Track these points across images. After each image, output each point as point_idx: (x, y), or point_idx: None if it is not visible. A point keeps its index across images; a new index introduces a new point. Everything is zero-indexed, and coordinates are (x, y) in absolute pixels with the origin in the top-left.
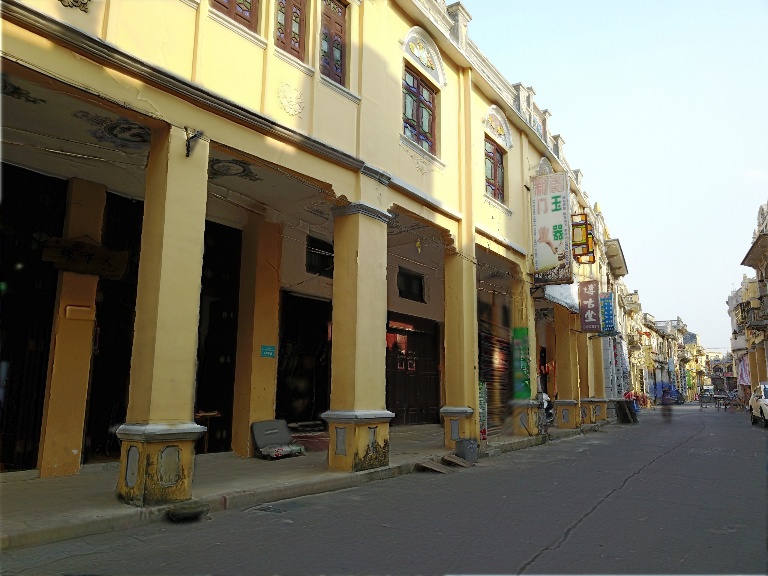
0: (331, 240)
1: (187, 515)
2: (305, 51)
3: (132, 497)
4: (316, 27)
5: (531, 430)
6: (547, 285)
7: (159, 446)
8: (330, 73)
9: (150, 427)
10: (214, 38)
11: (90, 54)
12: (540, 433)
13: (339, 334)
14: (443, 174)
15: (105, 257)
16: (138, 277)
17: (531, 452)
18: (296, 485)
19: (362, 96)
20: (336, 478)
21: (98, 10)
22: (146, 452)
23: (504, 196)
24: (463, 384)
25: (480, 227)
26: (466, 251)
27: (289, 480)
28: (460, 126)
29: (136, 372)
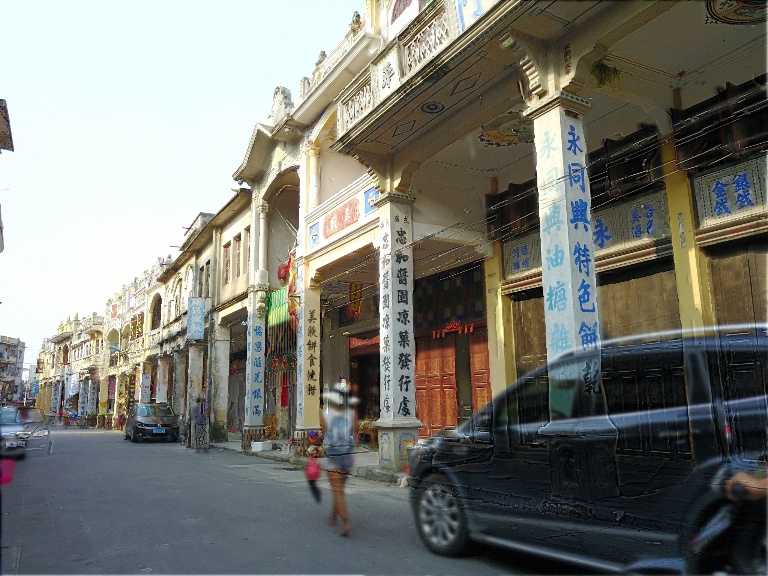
0: None
1: None
2: None
3: None
4: None
5: None
6: None
7: None
8: None
9: None
10: None
11: None
12: None
13: None
14: None
15: None
16: None
17: None
18: None
19: None
20: None
21: None
22: None
23: None
24: None
25: None
26: None
27: None
28: None
29: None
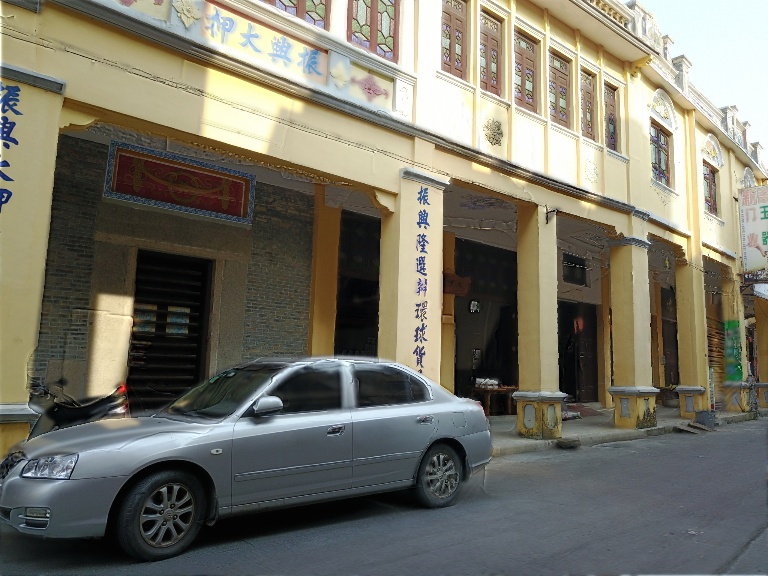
0: (607, 263)
1: (572, 445)
2: (595, 133)
3: (532, 434)
4: (603, 114)
5: (744, 407)
6: (755, 283)
7: (546, 404)
8: (608, 144)
9: (543, 393)
10: (553, 141)
11: (506, 172)
12: (751, 410)
13: (619, 332)
14: (677, 202)
15: (459, 282)
16: (518, 301)
17: (751, 424)
18: (610, 434)
19: (630, 157)
20: (630, 432)
21: (505, 143)
22: (541, 408)
23: (717, 209)
24: (696, 368)
25: (703, 240)
26: (695, 262)
27: (600, 432)
28: (687, 159)
29: (524, 360)
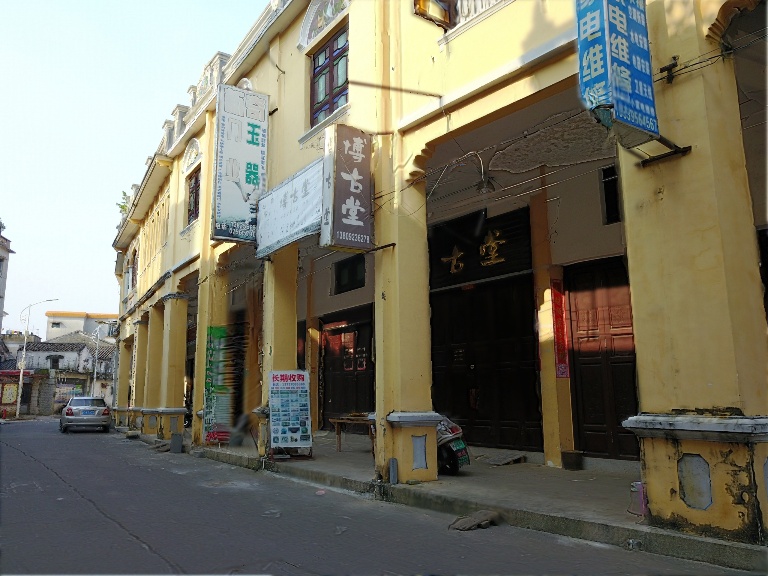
0: None
1: None
2: None
3: None
4: None
5: None
6: (261, 237)
7: None
8: None
9: None
10: None
11: None
12: None
13: None
14: None
15: None
16: None
17: (199, 463)
18: None
19: None
20: None
21: None
22: None
23: None
24: None
25: None
26: None
27: None
28: None
29: None
